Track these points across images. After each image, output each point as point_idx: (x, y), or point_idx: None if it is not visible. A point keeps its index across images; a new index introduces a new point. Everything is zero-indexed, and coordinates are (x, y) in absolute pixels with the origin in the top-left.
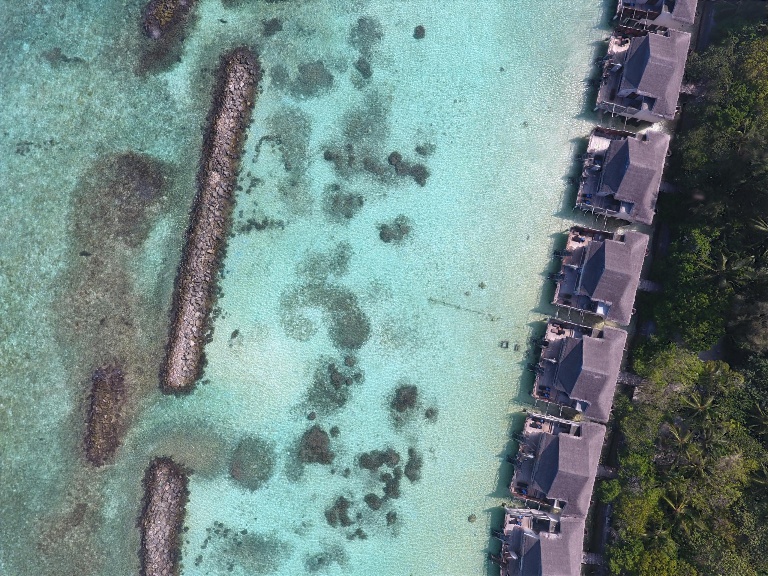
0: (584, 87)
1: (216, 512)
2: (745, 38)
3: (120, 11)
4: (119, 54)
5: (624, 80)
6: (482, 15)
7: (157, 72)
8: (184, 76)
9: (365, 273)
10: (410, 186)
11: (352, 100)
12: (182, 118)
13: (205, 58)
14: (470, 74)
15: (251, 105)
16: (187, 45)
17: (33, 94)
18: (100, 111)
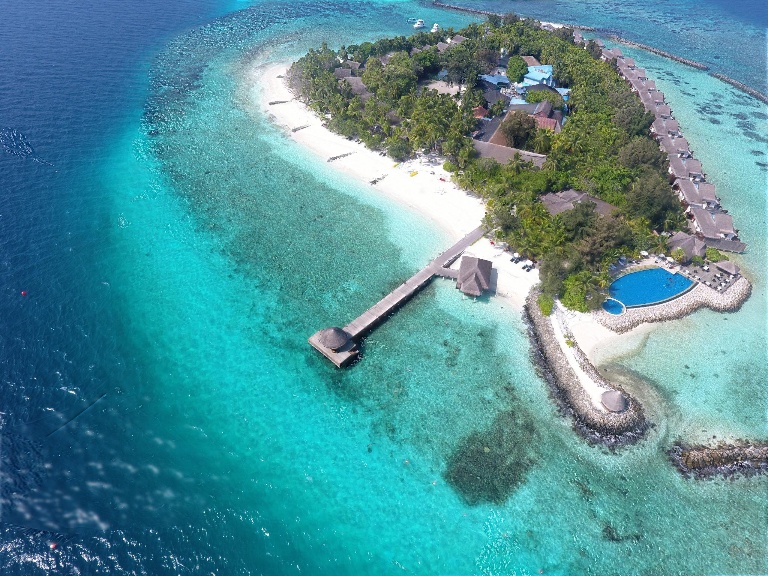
0: None
1: (762, 109)
2: None
3: None
4: None
5: None
6: None
7: None
8: None
9: (759, 145)
10: (762, 162)
11: None
12: None
13: None
14: None
15: None
16: None
17: None
18: None
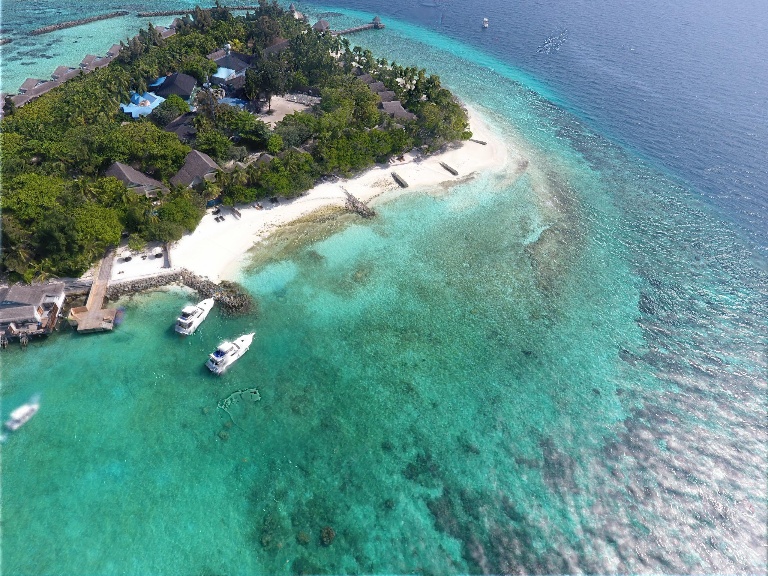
0: None
1: None
2: None
3: None
4: None
5: None
6: None
7: None
8: None
9: None
10: None
11: None
12: None
13: None
14: None
15: (0, 45)
16: None
17: None
18: None
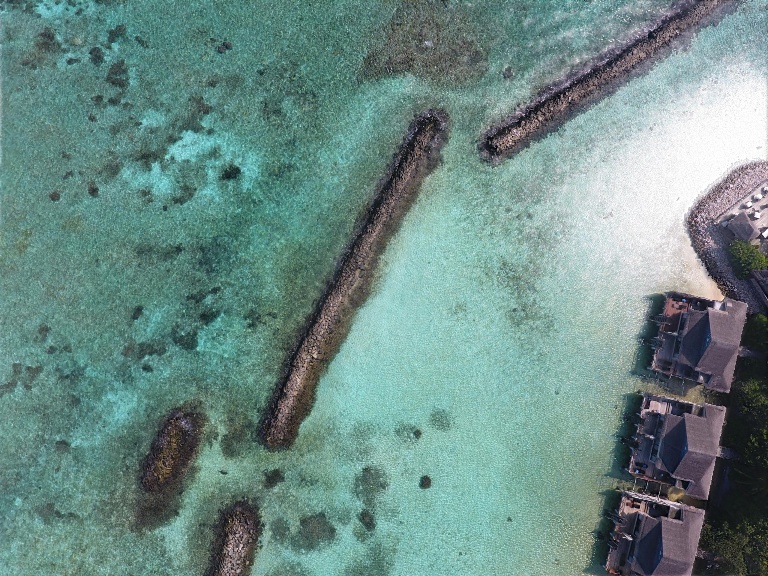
0: (593, 538)
1: None
2: (761, 532)
3: (117, 463)
4: (115, 509)
5: (635, 561)
6: (490, 462)
7: (154, 528)
8: (181, 531)
9: None
10: None
11: (354, 554)
12: (178, 575)
13: (204, 512)
14: (476, 525)
15: (250, 564)
16: (185, 498)
17: (24, 553)
18: (93, 570)
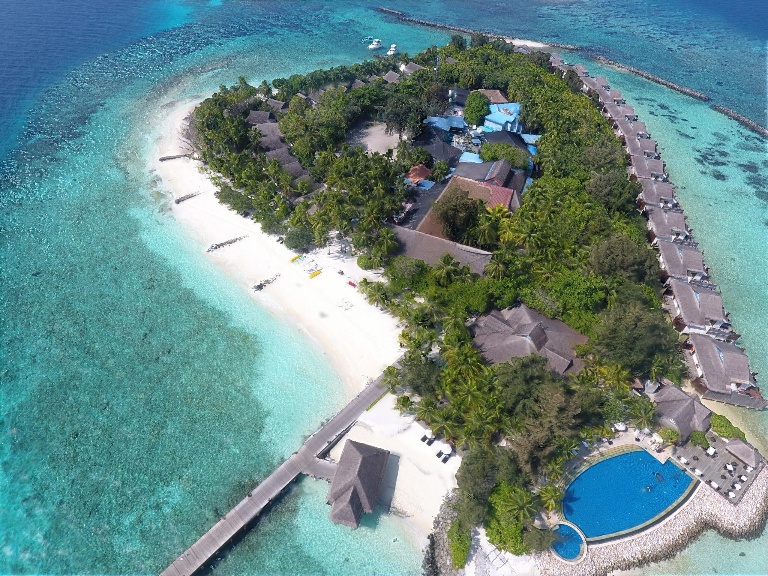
0: None
1: None
2: None
3: None
4: None
5: None
6: None
7: None
8: None
9: None
10: None
11: None
12: None
13: None
14: None
15: None
16: None
17: None
18: None
